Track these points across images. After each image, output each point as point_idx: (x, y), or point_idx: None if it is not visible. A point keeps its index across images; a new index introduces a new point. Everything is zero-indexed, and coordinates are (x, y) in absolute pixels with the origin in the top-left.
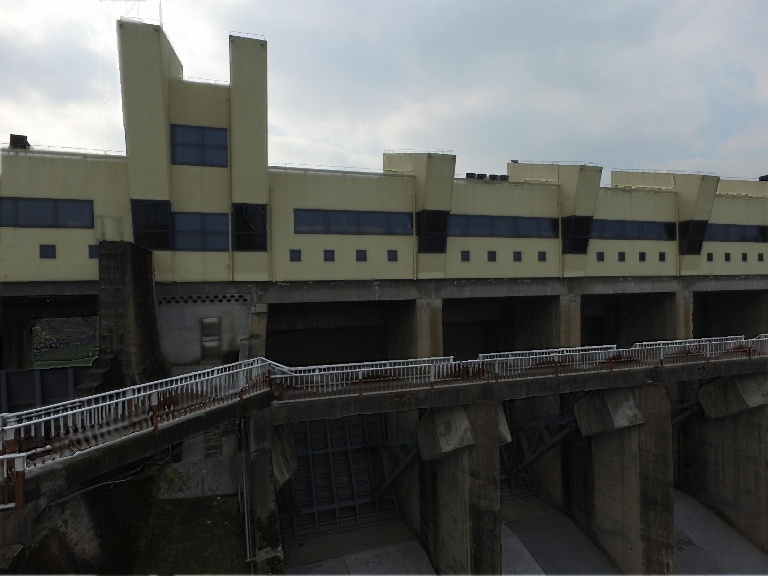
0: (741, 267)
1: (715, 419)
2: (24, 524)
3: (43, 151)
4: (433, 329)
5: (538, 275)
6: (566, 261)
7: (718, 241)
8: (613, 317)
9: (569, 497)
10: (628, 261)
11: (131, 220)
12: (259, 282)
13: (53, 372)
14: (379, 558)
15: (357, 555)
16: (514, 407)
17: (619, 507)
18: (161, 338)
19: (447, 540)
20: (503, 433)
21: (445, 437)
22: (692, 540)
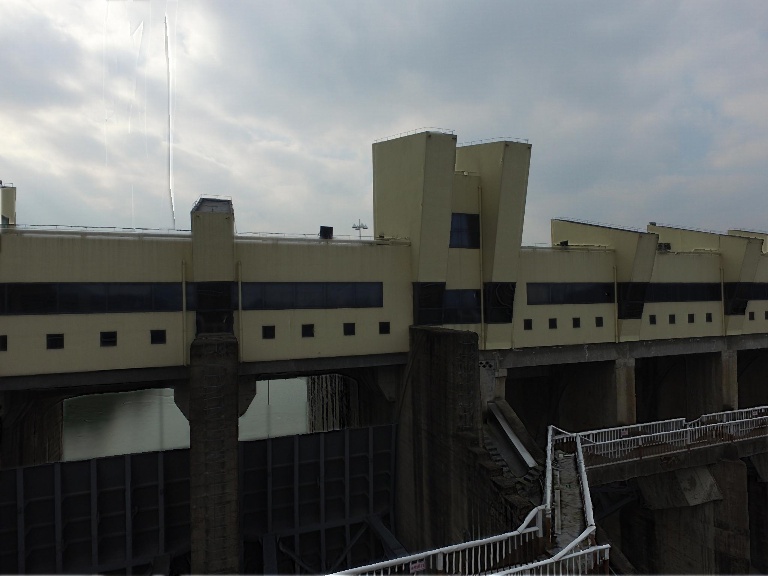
0: None
1: None
2: None
3: (346, 240)
4: (628, 386)
5: (706, 334)
6: (729, 321)
7: None
8: None
9: None
10: None
11: (410, 299)
12: (501, 349)
13: (333, 434)
14: None
15: None
16: None
17: None
18: None
19: None
20: None
21: (691, 492)
22: None
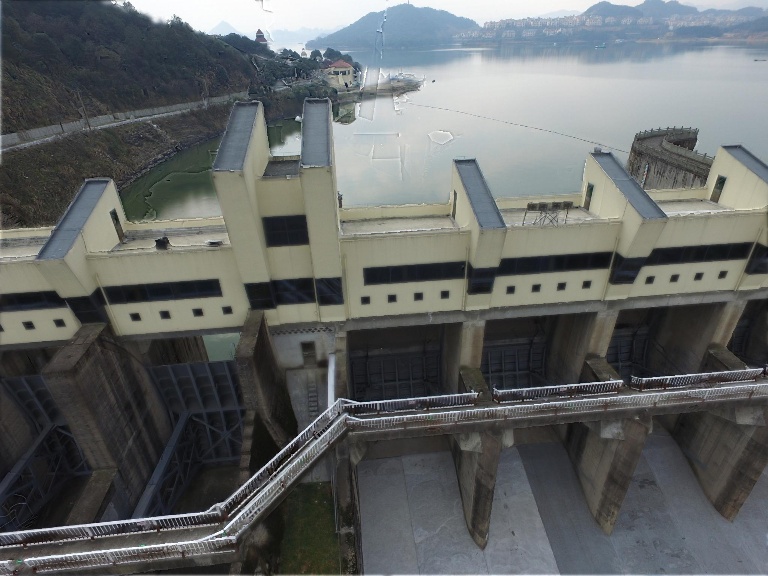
0: None
1: None
2: (240, 556)
3: (179, 250)
4: (475, 341)
5: (579, 299)
6: (610, 290)
7: None
8: None
9: (569, 440)
10: (681, 281)
11: None
12: None
13: (215, 364)
14: (424, 462)
15: (410, 457)
16: (549, 359)
17: (595, 470)
18: (277, 356)
19: (464, 475)
20: (506, 444)
21: (464, 442)
22: (656, 481)
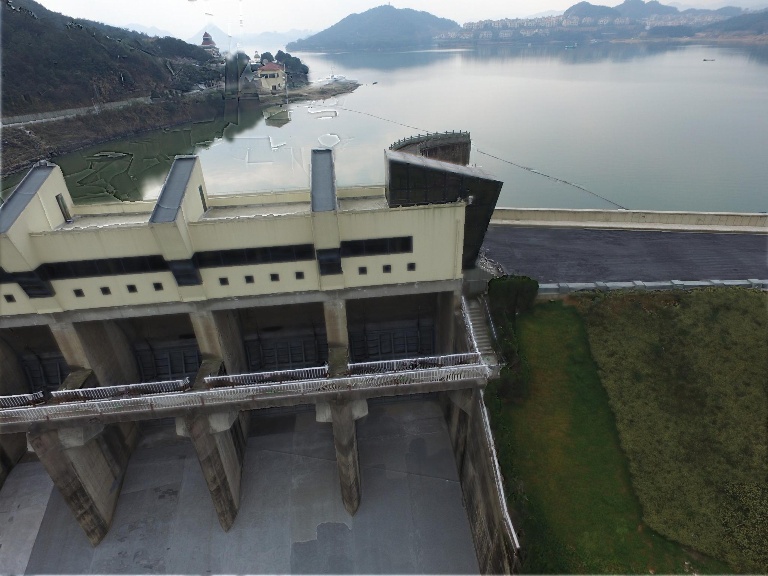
0: (272, 286)
1: None
2: None
3: None
4: None
5: (13, 313)
6: (32, 303)
7: (234, 266)
8: None
9: None
10: (116, 293)
11: None
12: None
13: None
14: None
15: None
16: None
17: None
18: None
19: None
20: None
21: None
22: (179, 491)
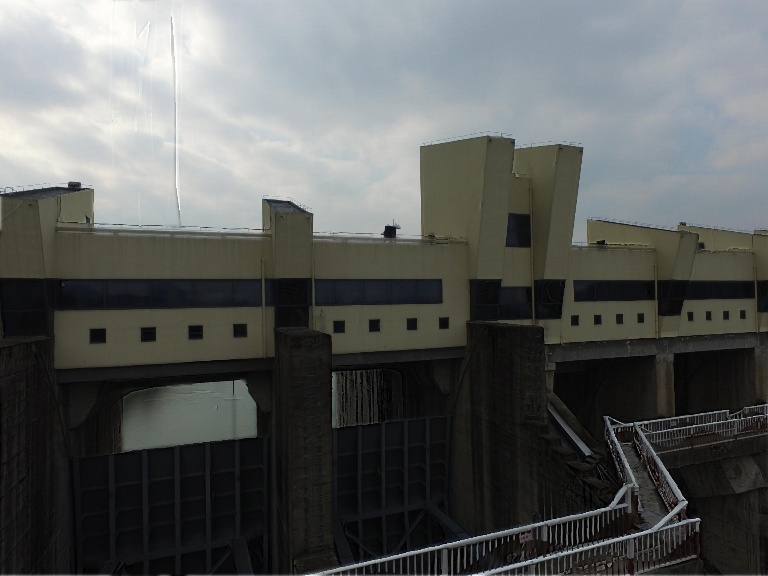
0: None
1: None
2: None
3: (409, 239)
4: (668, 380)
5: (741, 331)
6: (762, 318)
7: None
8: None
9: None
10: None
11: (467, 295)
12: (550, 344)
13: (393, 425)
14: None
15: None
16: None
17: None
18: None
19: (718, 568)
20: None
21: (736, 480)
22: None
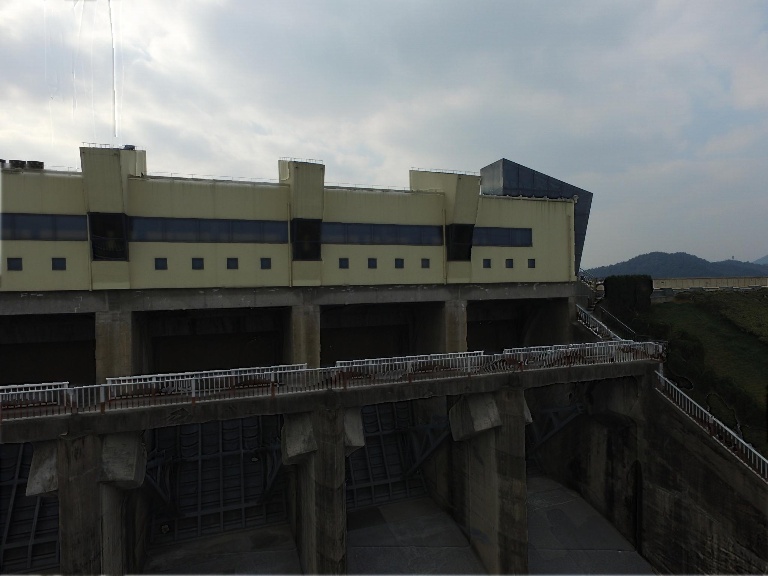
0: (395, 275)
1: (299, 465)
2: None
3: None
4: None
5: (52, 288)
6: (93, 270)
7: (358, 244)
8: (281, 333)
9: None
10: (209, 269)
11: None
12: None
13: None
14: None
15: None
16: None
17: None
18: None
19: None
20: None
21: None
22: None
